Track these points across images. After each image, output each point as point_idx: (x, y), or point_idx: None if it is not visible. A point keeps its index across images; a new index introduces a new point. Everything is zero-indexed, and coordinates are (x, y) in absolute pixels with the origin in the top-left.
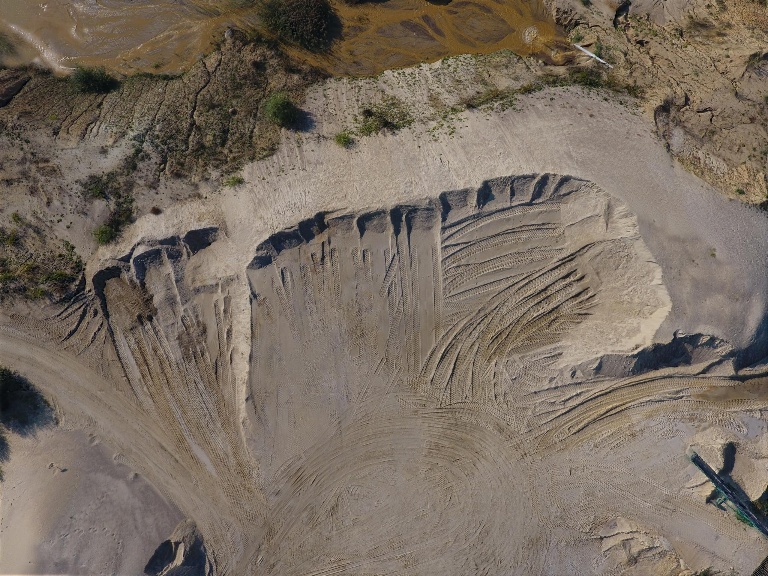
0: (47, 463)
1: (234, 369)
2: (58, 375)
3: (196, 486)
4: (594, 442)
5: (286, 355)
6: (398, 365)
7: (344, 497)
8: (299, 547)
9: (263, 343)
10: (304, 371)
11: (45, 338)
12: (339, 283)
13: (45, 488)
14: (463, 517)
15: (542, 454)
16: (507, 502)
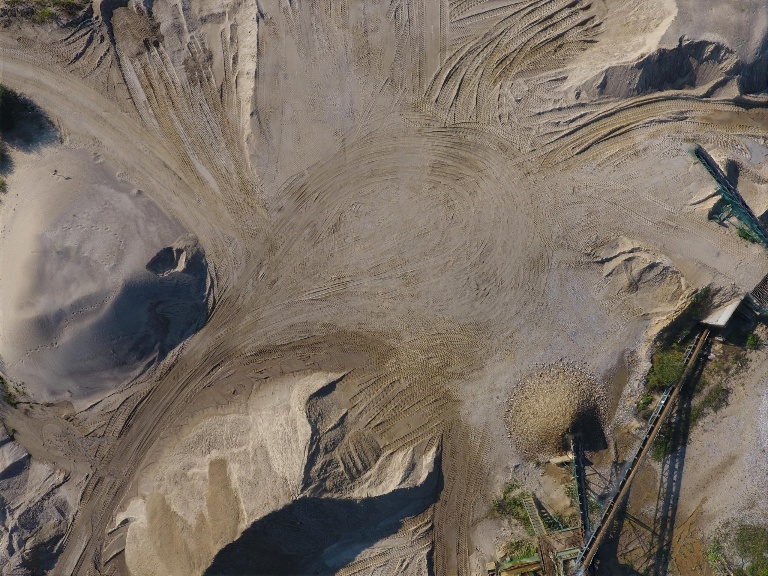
0: (51, 172)
1: (239, 92)
2: (63, 97)
3: (199, 203)
4: (597, 161)
5: (292, 72)
6: (403, 85)
7: (346, 215)
8: (300, 264)
9: (269, 60)
10: (309, 89)
11: (51, 61)
12: (346, 5)
13: (48, 190)
14: (465, 236)
15: (545, 173)
16: (509, 221)
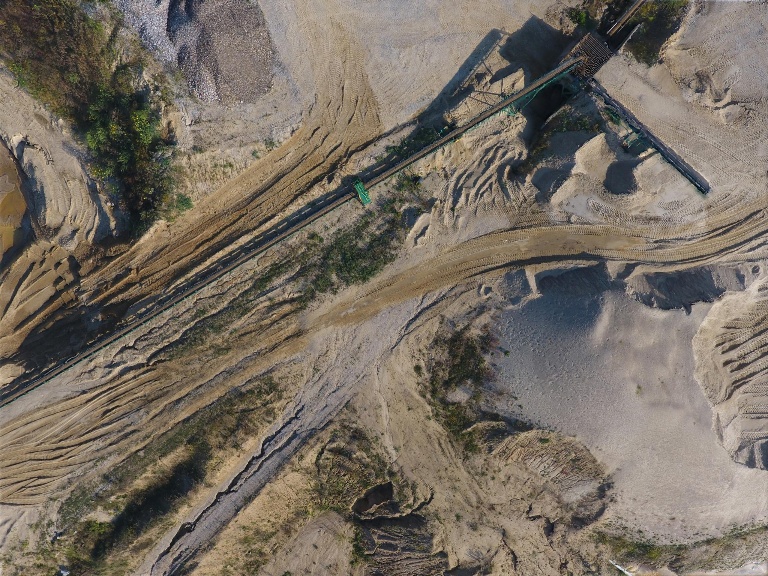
0: None
1: None
2: None
3: None
4: (744, 201)
5: None
6: None
7: None
8: None
9: None
10: None
11: None
12: None
13: None
14: None
15: None
16: None
